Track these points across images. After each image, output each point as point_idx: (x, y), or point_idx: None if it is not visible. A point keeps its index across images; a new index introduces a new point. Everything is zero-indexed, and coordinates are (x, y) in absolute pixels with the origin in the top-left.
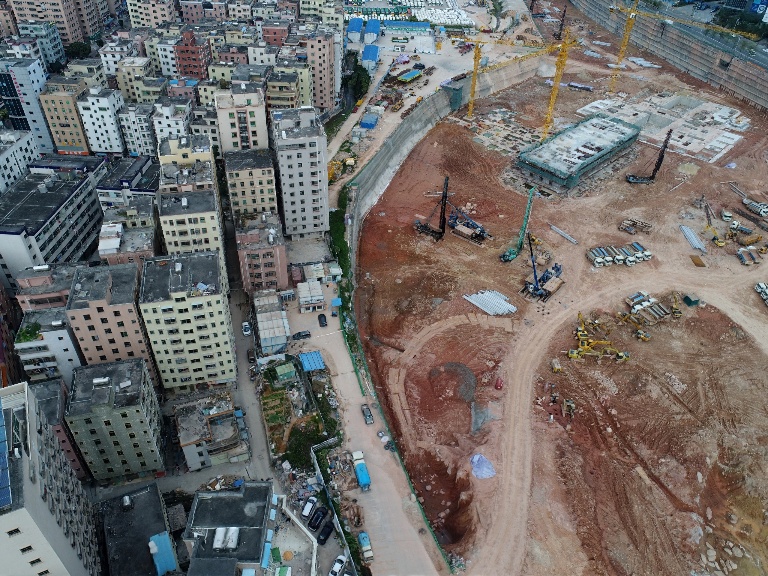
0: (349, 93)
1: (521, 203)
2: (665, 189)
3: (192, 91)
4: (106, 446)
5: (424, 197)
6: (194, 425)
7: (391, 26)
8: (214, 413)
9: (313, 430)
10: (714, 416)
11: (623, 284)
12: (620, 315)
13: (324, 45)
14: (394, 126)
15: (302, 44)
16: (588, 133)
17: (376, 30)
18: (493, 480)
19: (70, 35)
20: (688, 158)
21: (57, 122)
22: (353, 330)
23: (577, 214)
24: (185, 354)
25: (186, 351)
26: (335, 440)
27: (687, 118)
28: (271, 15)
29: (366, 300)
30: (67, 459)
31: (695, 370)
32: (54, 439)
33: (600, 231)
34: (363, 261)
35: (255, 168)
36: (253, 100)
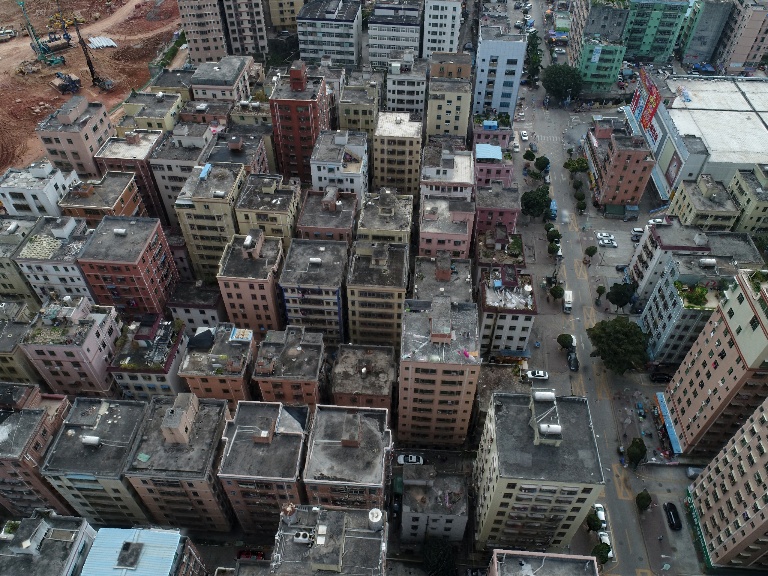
0: None
1: None
2: None
3: None
4: None
5: None
6: None
7: None
8: None
9: None
10: (40, 2)
11: None
12: None
13: None
14: None
15: None
16: None
17: None
18: None
19: None
20: None
21: None
22: None
23: None
24: None
25: None
26: None
27: None
28: None
29: None
30: None
31: None
32: None
33: None
34: None
35: None
36: None
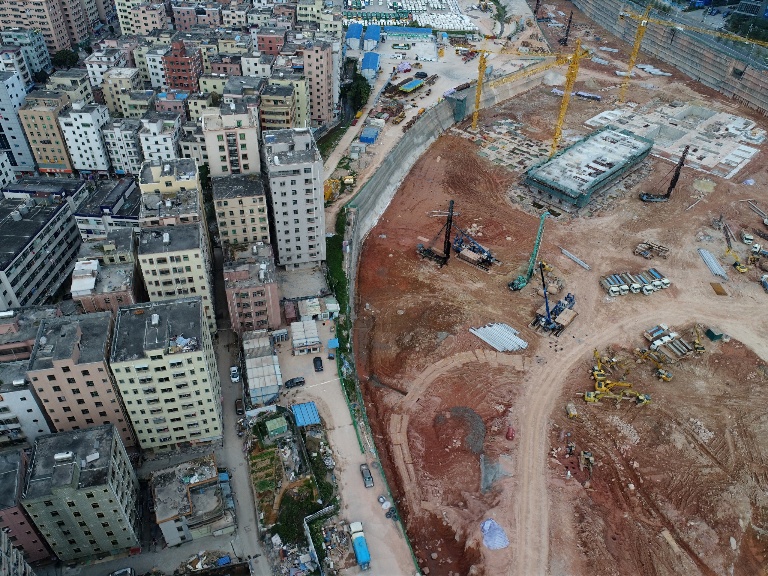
0: (348, 104)
1: (529, 224)
2: (681, 208)
3: (181, 105)
4: (71, 527)
5: (427, 217)
6: (172, 497)
7: (392, 32)
8: (195, 481)
9: (306, 497)
10: (745, 470)
11: (640, 315)
12: (639, 352)
13: (322, 55)
14: (395, 140)
15: (299, 53)
16: (598, 147)
17: (376, 36)
18: (506, 551)
19: (57, 42)
20: (703, 174)
21: (38, 139)
22: (351, 375)
23: (589, 236)
24: (164, 413)
25: (165, 410)
26: (331, 508)
27: (700, 130)
28: (267, 21)
29: (366, 334)
30: (20, 555)
31: (722, 415)
32: (1, 540)
33: (614, 255)
34: (362, 289)
35: (245, 196)
36: (243, 121)
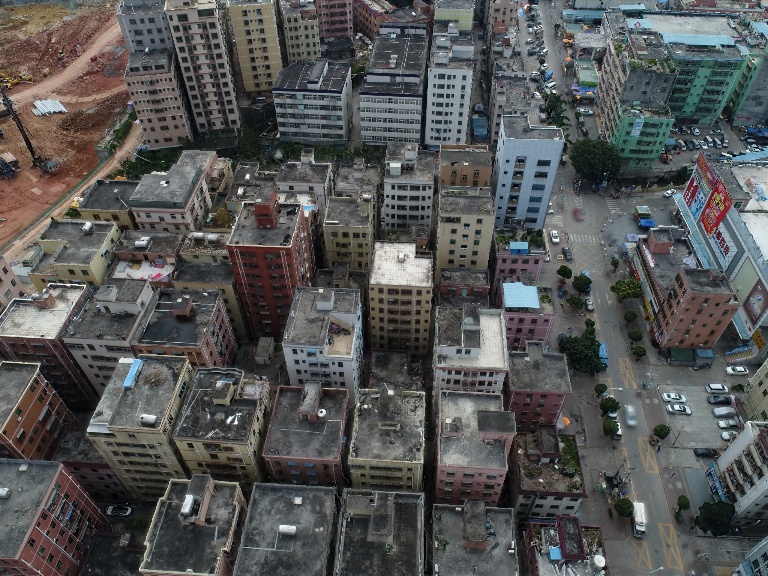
0: None
1: None
2: None
3: None
4: None
5: (8, 218)
6: None
7: None
8: None
9: None
10: None
11: None
12: None
13: None
14: None
15: None
16: None
17: None
18: None
19: None
20: None
21: None
22: None
23: None
24: None
25: None
26: None
27: None
28: None
29: None
30: None
31: None
32: None
33: None
34: None
35: None
36: None
